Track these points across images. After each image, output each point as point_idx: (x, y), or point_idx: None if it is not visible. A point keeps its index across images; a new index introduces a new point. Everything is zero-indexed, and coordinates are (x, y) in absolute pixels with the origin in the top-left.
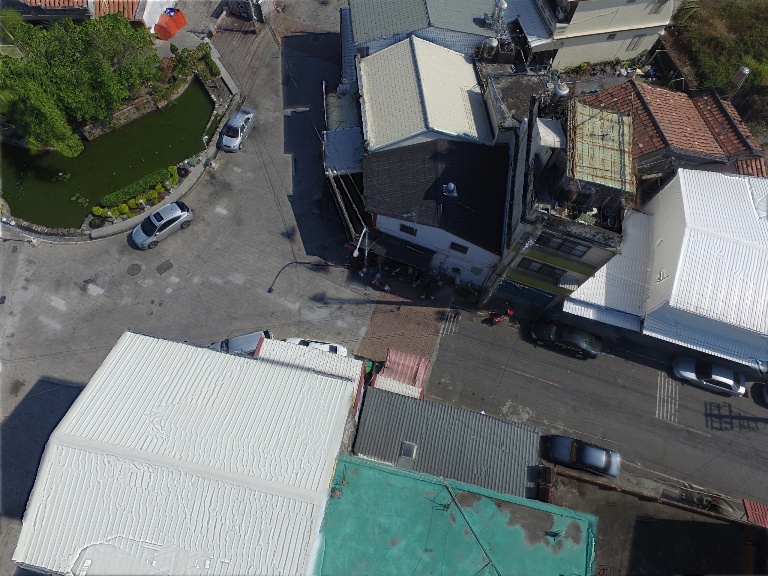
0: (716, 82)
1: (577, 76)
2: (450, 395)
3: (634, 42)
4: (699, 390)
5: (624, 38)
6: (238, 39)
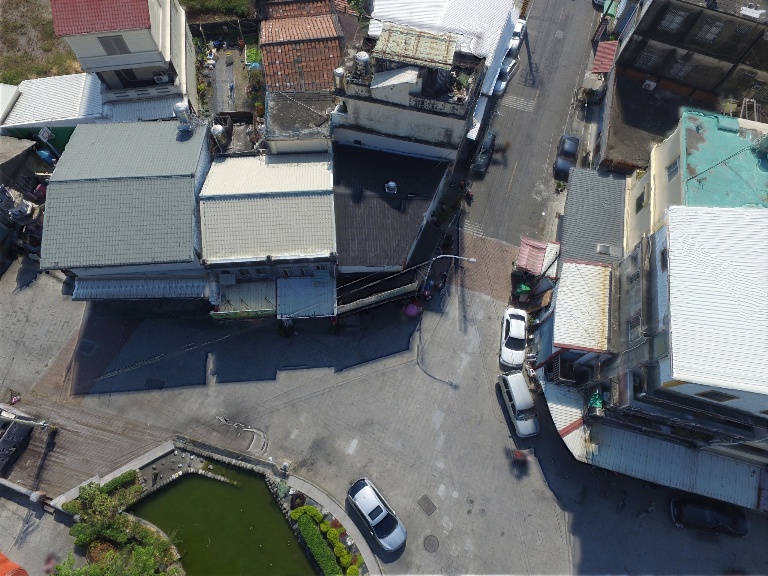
0: (245, 2)
1: (208, 97)
2: (533, 234)
3: (188, 42)
4: (509, 85)
5: (186, 46)
6: (62, 455)
